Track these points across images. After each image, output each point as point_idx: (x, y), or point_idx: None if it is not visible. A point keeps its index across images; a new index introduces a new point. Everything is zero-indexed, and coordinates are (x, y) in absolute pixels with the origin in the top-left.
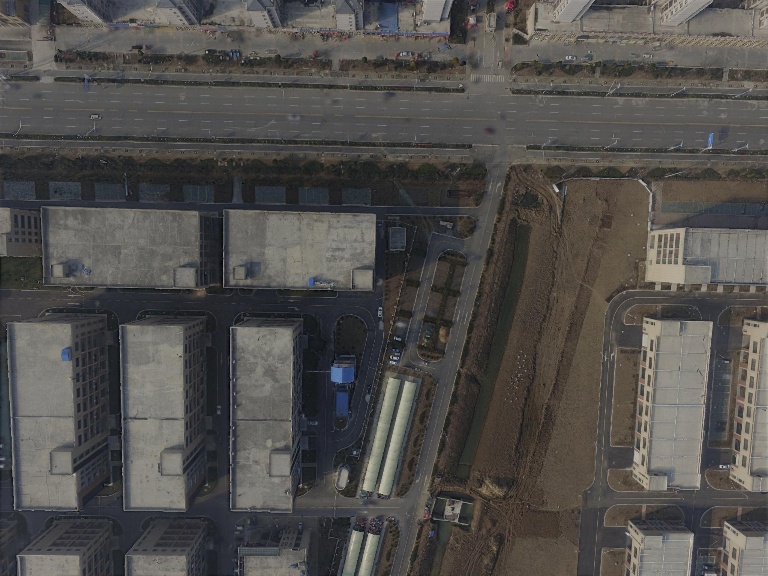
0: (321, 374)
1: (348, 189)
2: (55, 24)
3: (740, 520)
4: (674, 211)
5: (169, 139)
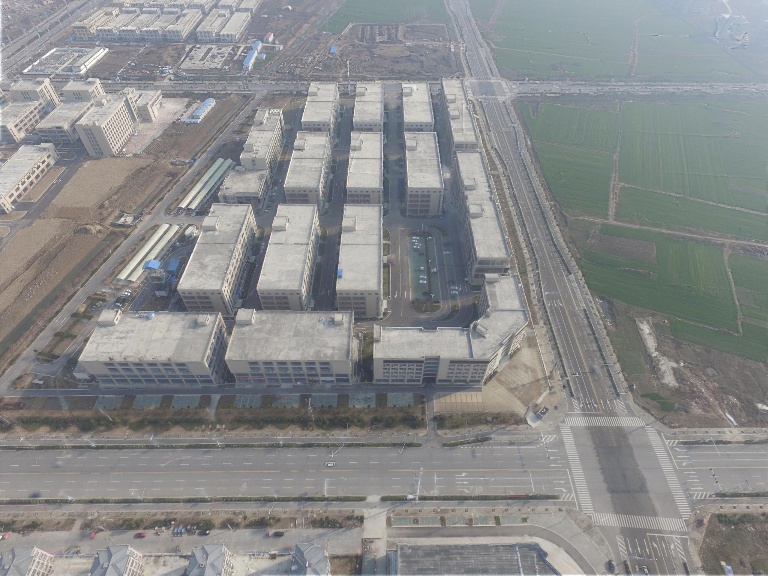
0: None
1: None
2: None
3: None
4: None
5: (265, 446)
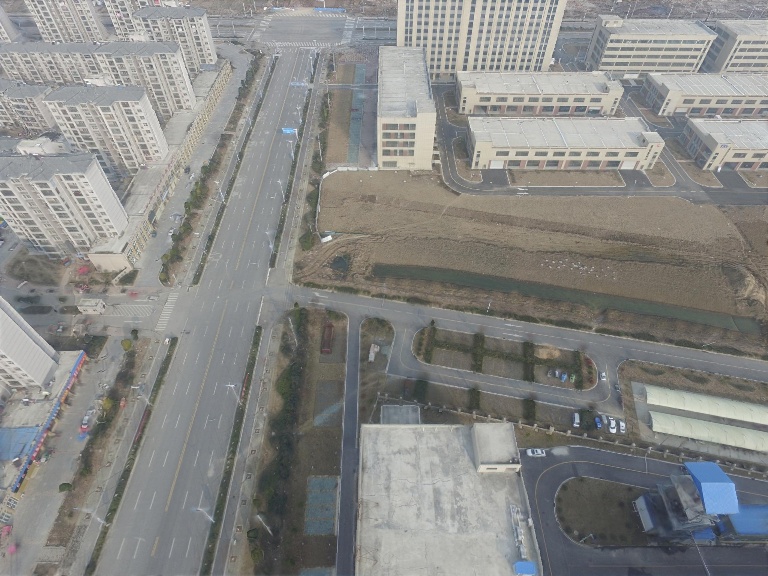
0: None
1: (305, 523)
2: None
3: (651, 108)
4: (357, 155)
5: None
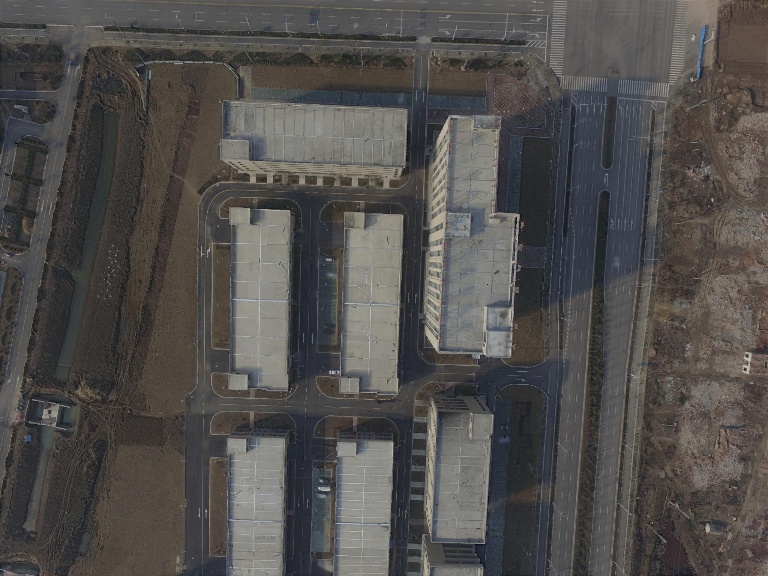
0: None
1: None
2: None
3: (356, 431)
4: (265, 98)
5: None
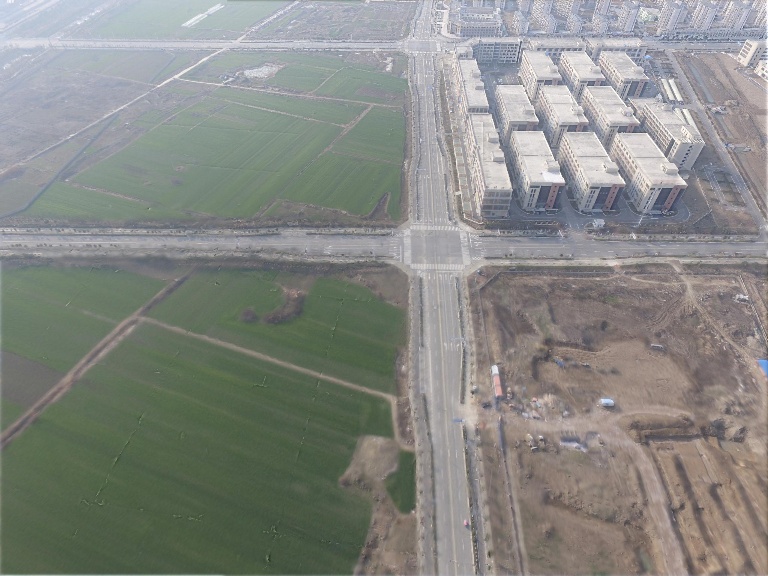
0: None
1: None
2: (510, 36)
3: None
4: None
5: None
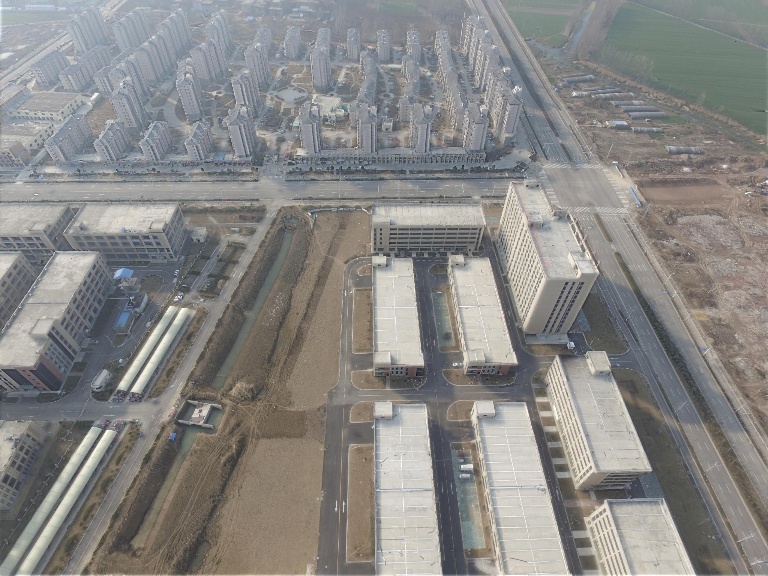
0: (116, 309)
1: None
2: (39, 164)
3: None
4: None
5: (75, 201)
